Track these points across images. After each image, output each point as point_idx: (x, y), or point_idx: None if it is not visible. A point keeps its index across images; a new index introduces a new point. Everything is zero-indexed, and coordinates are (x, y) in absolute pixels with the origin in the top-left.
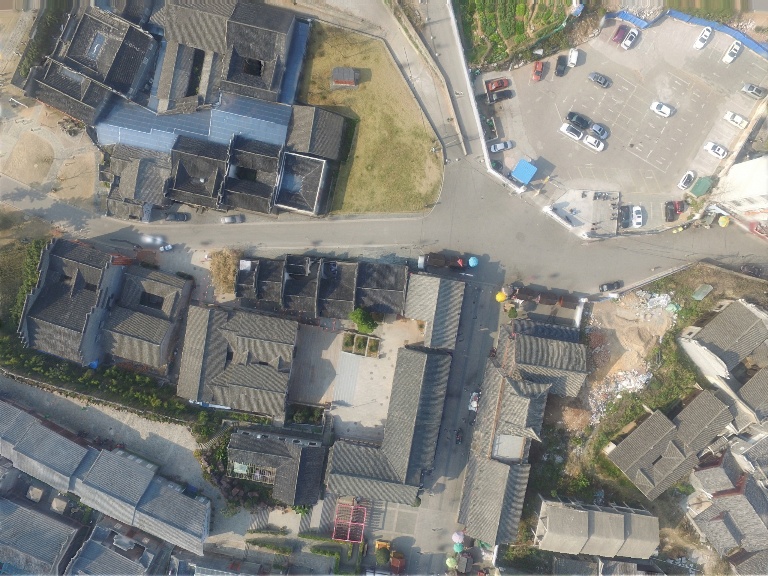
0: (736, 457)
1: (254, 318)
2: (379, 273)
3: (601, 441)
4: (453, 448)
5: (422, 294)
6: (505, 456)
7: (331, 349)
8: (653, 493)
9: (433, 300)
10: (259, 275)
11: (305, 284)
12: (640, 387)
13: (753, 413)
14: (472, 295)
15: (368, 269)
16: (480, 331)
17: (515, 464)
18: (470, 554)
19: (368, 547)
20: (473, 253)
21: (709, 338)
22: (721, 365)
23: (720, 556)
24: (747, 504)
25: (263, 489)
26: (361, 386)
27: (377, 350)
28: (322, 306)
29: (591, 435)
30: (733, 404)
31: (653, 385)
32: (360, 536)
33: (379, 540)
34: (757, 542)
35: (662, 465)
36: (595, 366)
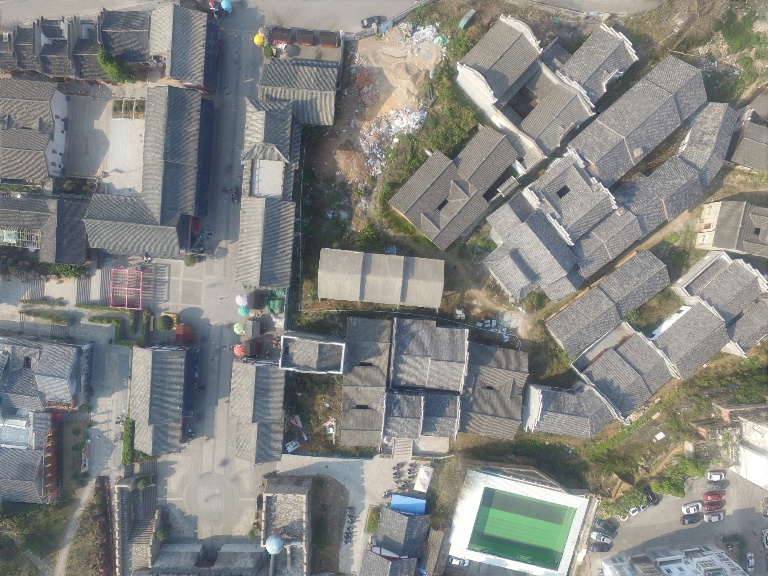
0: (526, 196)
1: (13, 82)
2: (127, 18)
3: (387, 194)
4: (231, 209)
5: (162, 26)
6: (267, 194)
7: (103, 119)
8: (442, 240)
9: (170, 28)
10: (16, 39)
11: (64, 46)
12: (414, 126)
13: (532, 140)
14: (234, 45)
15: (116, 16)
16: (246, 82)
17: (275, 199)
18: (260, 321)
19: (155, 321)
20: (230, 0)
21: (473, 60)
22: (480, 79)
23: (517, 301)
24: (530, 233)
25: (35, 259)
26: (132, 150)
27: (144, 111)
28: (80, 64)
29: (375, 187)
30: (516, 139)
31: (428, 123)
32: (139, 303)
33: (165, 312)
34: (551, 279)
35: (448, 209)
36: (363, 105)
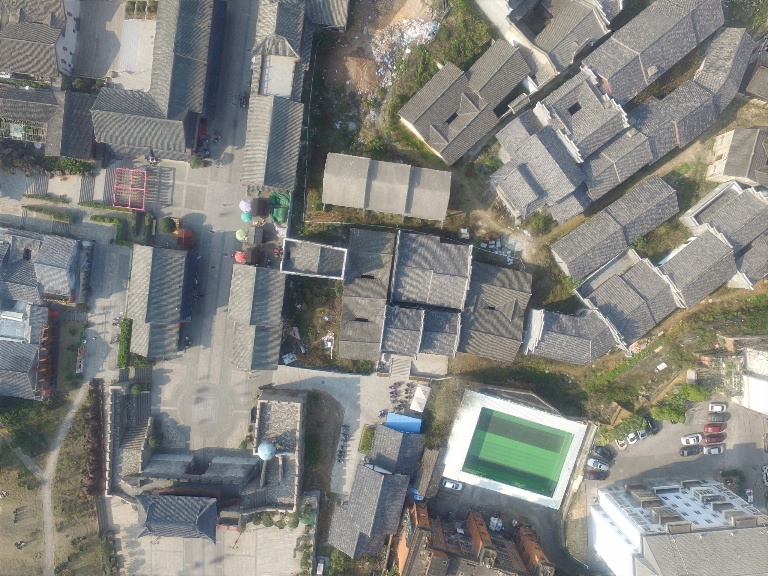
0: (537, 113)
1: None
2: None
3: (397, 107)
4: (239, 114)
5: None
6: (275, 94)
7: (115, 20)
8: (449, 154)
9: None
10: None
11: None
12: (427, 36)
13: (545, 54)
14: None
15: None
16: None
17: (283, 98)
18: (263, 230)
19: (157, 225)
20: None
21: None
22: None
23: (523, 217)
24: (540, 145)
25: (40, 154)
26: (142, 51)
27: (156, 11)
28: None
29: (385, 99)
30: (529, 55)
31: (441, 34)
32: (142, 203)
33: (168, 217)
34: (559, 195)
35: (457, 122)
36: (377, 13)
